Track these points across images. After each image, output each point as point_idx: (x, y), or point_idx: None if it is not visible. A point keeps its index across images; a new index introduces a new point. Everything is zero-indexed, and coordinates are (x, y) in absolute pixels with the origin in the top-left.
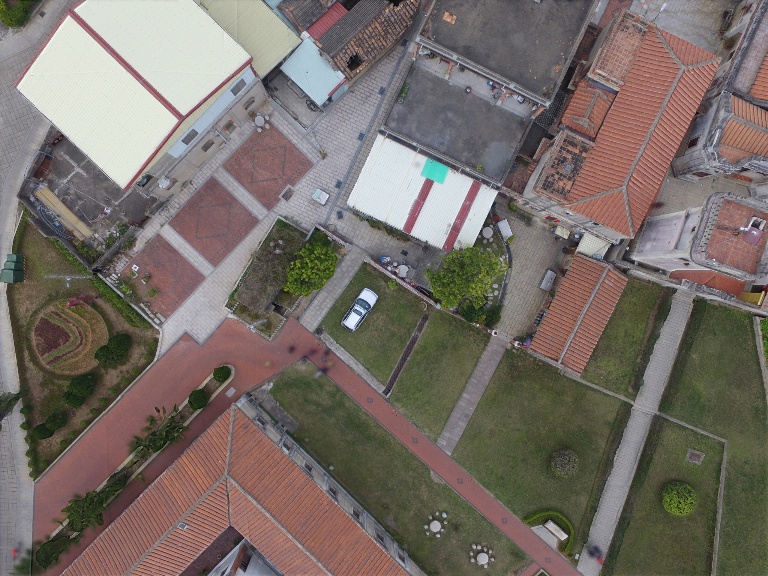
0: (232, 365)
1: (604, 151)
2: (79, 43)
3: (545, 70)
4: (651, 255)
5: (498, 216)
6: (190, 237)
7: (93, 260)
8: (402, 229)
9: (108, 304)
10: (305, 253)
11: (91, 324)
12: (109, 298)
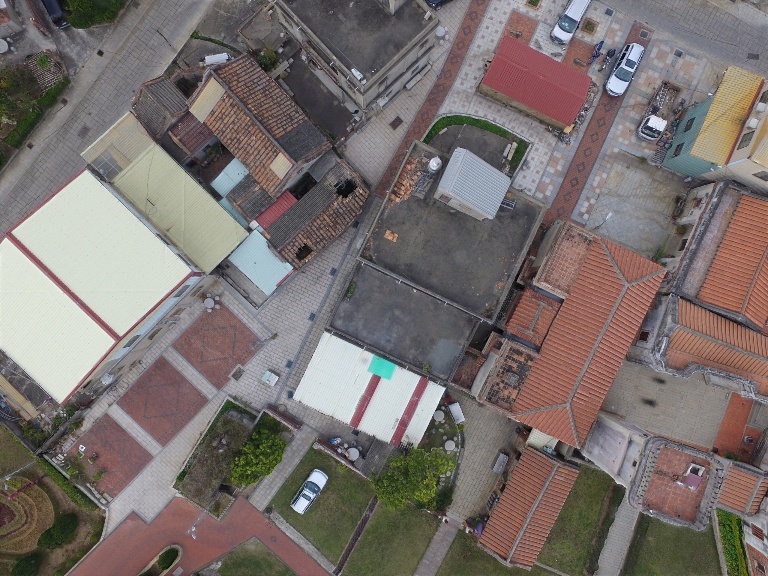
0: (179, 545)
1: (549, 362)
2: (16, 264)
3: (488, 287)
4: (598, 464)
5: (450, 397)
6: (138, 417)
7: (38, 442)
8: (349, 423)
9: (54, 482)
10: (250, 449)
11: (37, 502)
12: (55, 479)
